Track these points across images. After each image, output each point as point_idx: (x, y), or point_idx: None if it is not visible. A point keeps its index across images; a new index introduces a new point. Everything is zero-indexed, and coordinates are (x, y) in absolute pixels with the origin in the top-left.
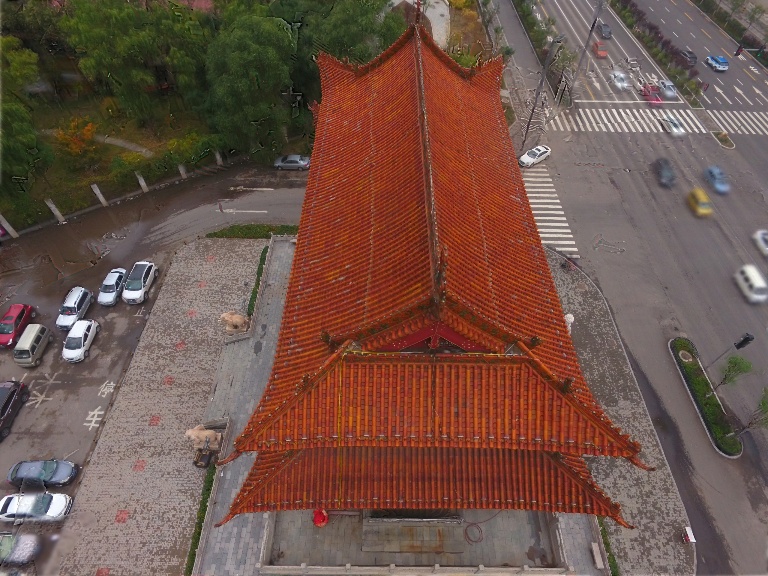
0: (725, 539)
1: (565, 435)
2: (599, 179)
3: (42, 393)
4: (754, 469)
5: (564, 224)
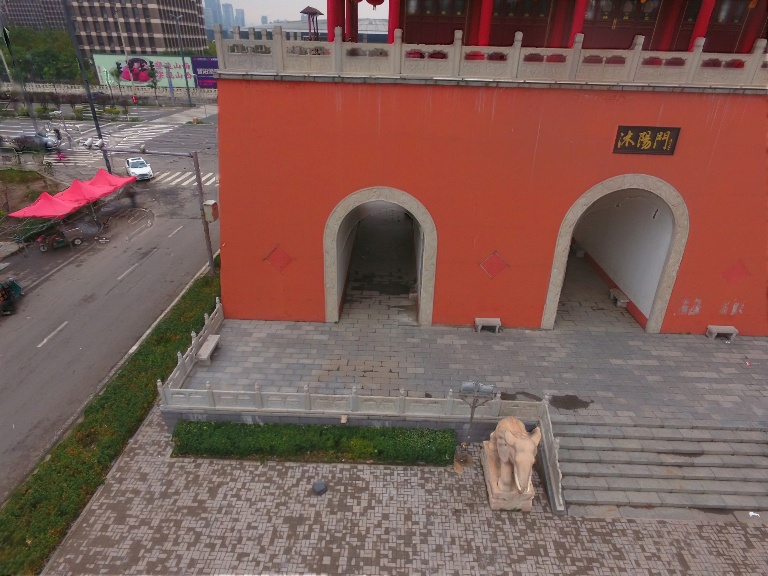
0: None
1: None
2: (211, 157)
3: None
4: None
5: None
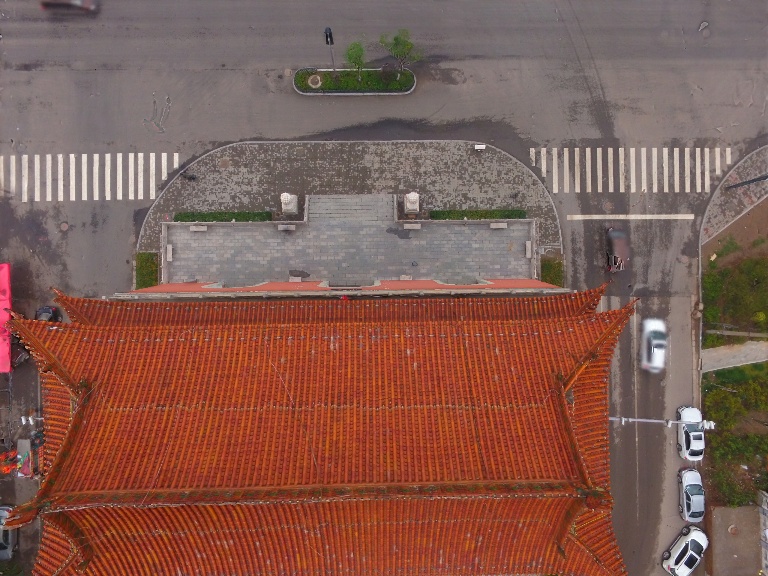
0: (478, 117)
1: (607, 351)
2: (21, 85)
3: None
4: (424, 68)
5: (119, 159)
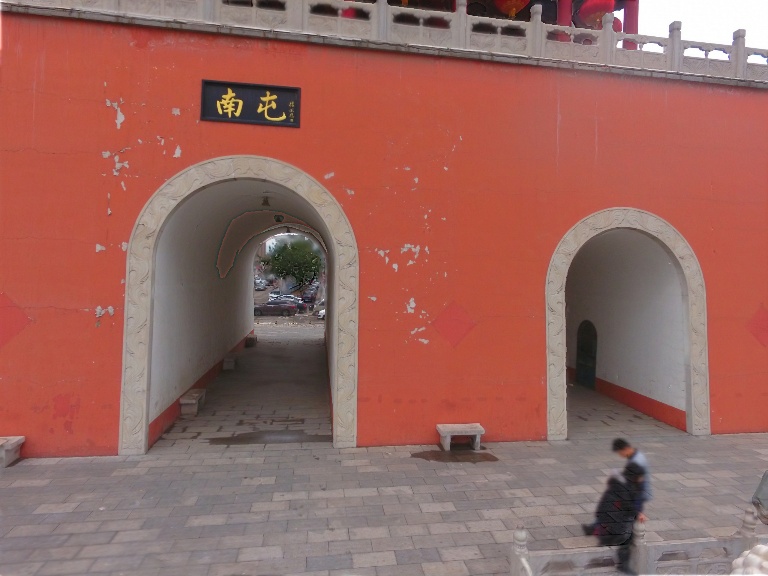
0: None
1: None
2: None
3: (291, 317)
4: None
5: None
